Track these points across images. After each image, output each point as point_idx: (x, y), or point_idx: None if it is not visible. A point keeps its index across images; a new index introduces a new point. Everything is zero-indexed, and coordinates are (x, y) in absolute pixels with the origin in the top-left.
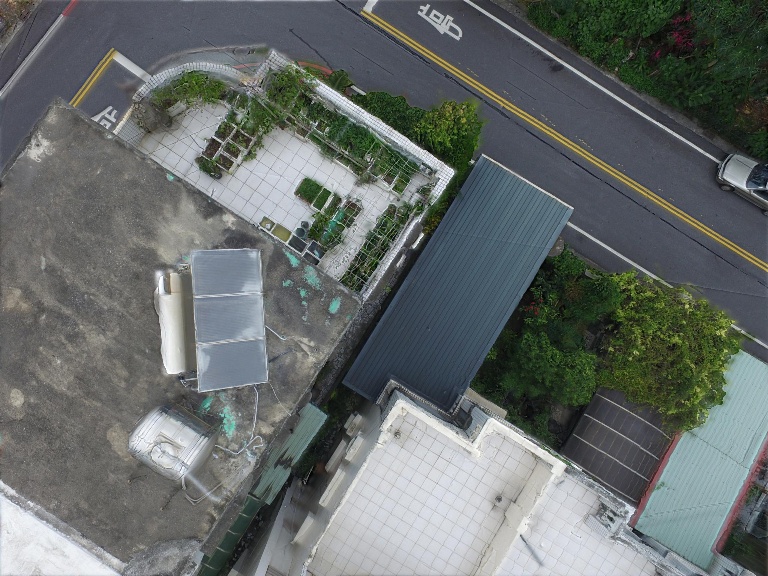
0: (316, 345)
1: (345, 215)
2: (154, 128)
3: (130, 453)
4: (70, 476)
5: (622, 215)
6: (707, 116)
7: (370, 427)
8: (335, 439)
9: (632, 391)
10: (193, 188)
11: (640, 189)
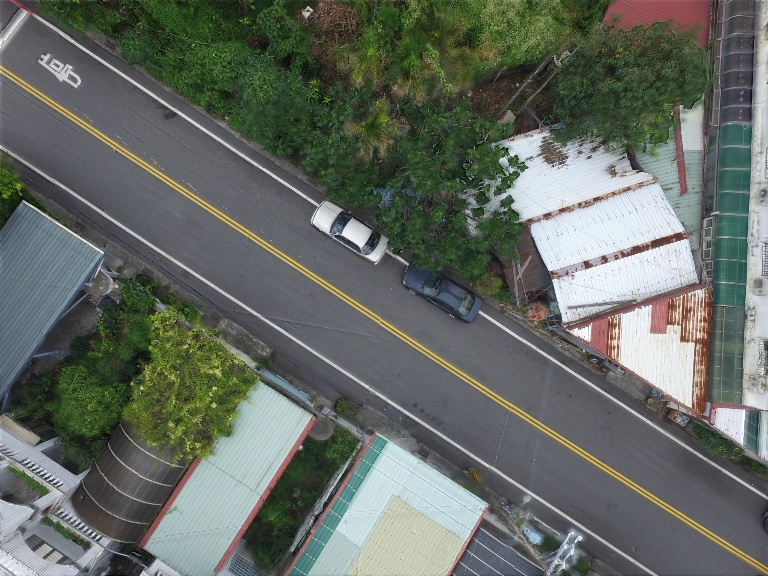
0: None
1: None
2: None
3: None
4: None
5: (224, 254)
6: None
7: None
8: None
9: (137, 423)
10: None
11: (242, 230)
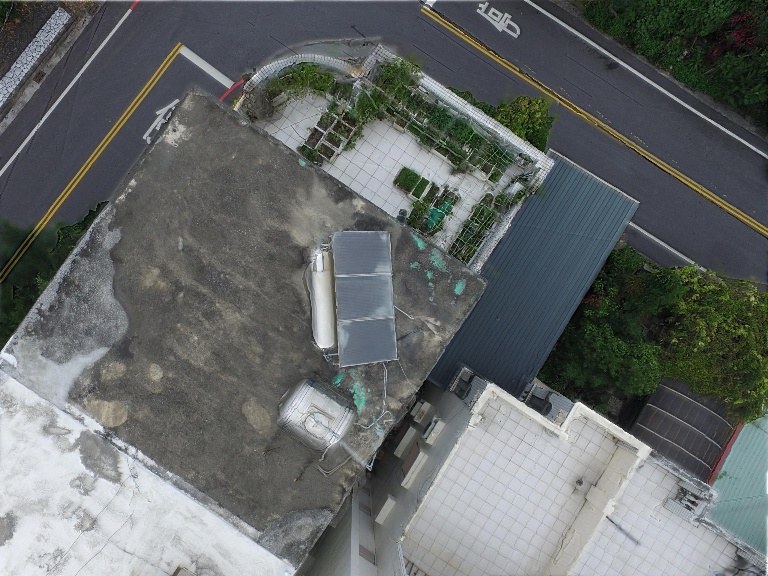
0: (442, 325)
1: (443, 203)
2: (262, 117)
3: (280, 423)
4: (207, 448)
5: (676, 211)
6: (760, 114)
7: (450, 412)
8: (400, 426)
9: (697, 381)
10: (325, 173)
11: (694, 185)
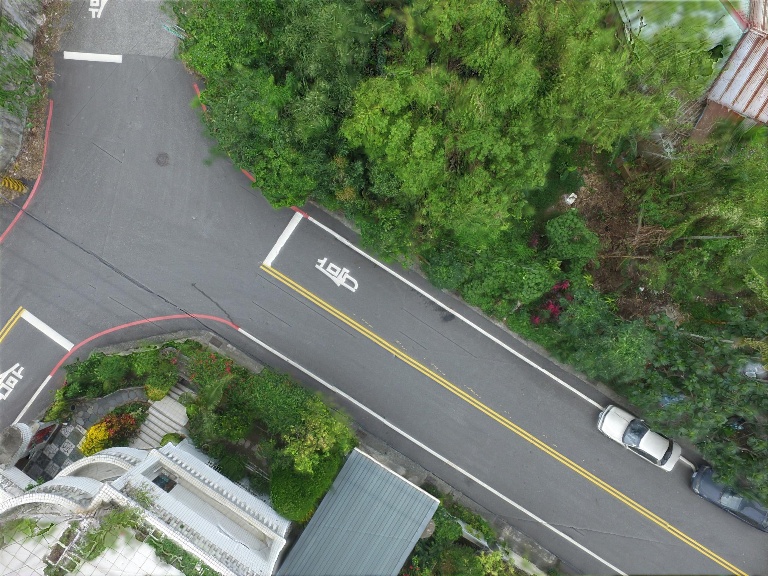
0: None
1: None
2: None
3: None
4: None
5: (507, 460)
6: None
7: None
8: None
9: None
10: None
11: (525, 435)
